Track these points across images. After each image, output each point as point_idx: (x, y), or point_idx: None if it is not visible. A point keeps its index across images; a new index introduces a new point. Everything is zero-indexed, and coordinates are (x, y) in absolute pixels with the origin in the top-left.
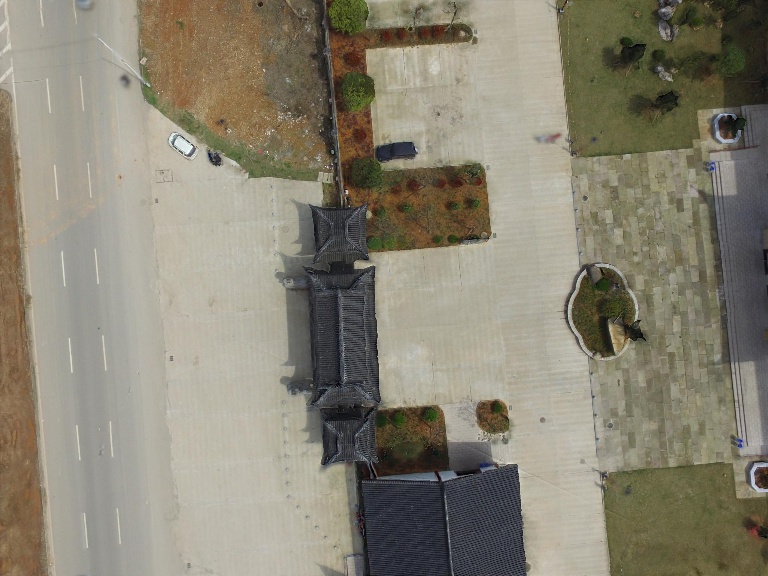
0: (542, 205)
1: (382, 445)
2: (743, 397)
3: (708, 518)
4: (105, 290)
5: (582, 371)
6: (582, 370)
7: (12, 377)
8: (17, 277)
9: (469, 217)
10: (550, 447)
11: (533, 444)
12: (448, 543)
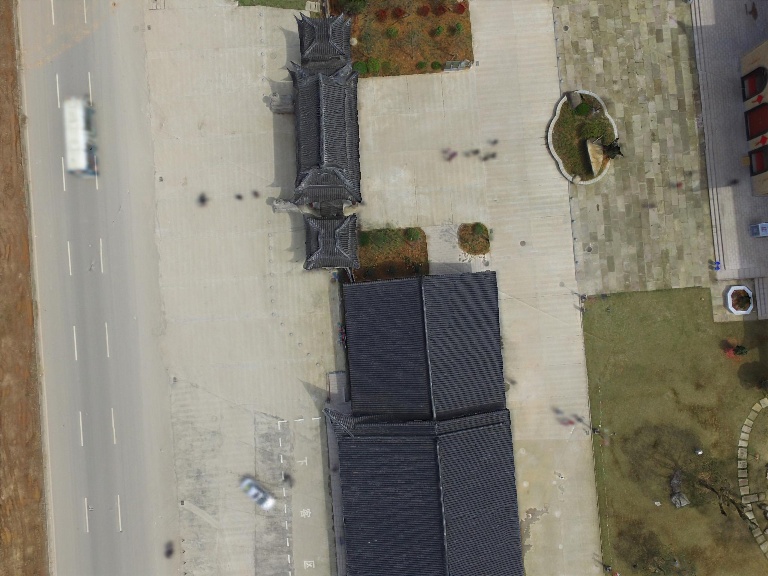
0: (524, 34)
1: (365, 264)
2: (721, 222)
3: (685, 340)
4: (98, 112)
5: (562, 196)
6: (562, 195)
7: (7, 193)
8: (13, 97)
9: (452, 45)
10: (530, 270)
11: (513, 267)
12: (425, 333)
